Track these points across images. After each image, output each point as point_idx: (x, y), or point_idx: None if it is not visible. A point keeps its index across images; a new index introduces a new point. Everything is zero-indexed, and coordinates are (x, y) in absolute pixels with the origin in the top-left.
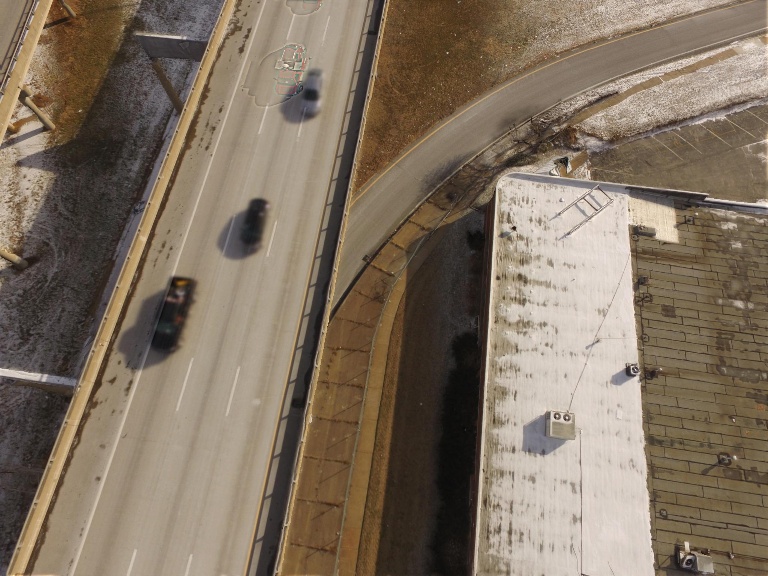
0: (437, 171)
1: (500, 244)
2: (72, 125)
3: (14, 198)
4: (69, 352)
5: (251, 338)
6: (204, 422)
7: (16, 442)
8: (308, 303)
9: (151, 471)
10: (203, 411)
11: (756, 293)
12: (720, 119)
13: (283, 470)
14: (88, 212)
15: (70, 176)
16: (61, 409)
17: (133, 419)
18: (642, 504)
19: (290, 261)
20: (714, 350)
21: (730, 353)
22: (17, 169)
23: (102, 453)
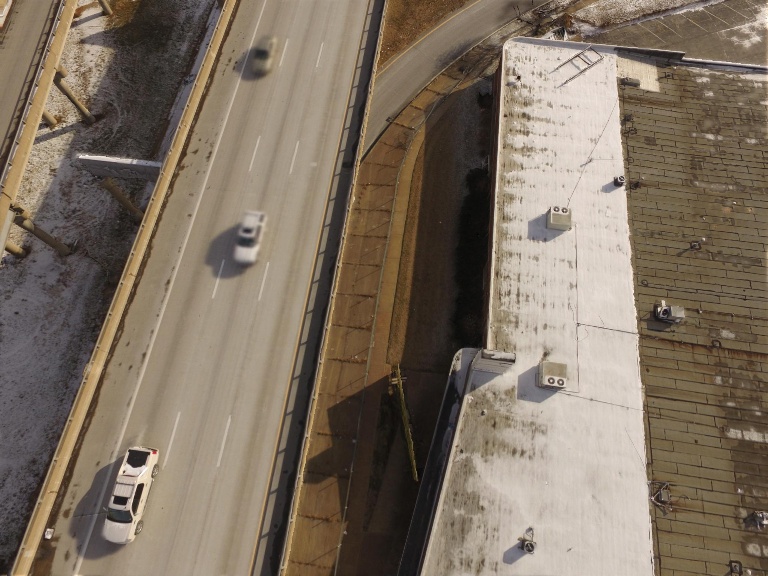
0: (450, 52)
1: (507, 91)
2: (127, 11)
3: (80, 69)
4: (135, 188)
5: (307, 122)
6: (272, 178)
7: (95, 254)
8: (352, 98)
9: (232, 210)
10: (271, 170)
11: (725, 128)
12: (698, 10)
13: (338, 207)
14: (145, 81)
15: (128, 52)
16: (131, 230)
17: (214, 176)
18: (627, 276)
19: (336, 70)
20: (688, 169)
21: (702, 171)
22: (81, 46)
23: (191, 199)
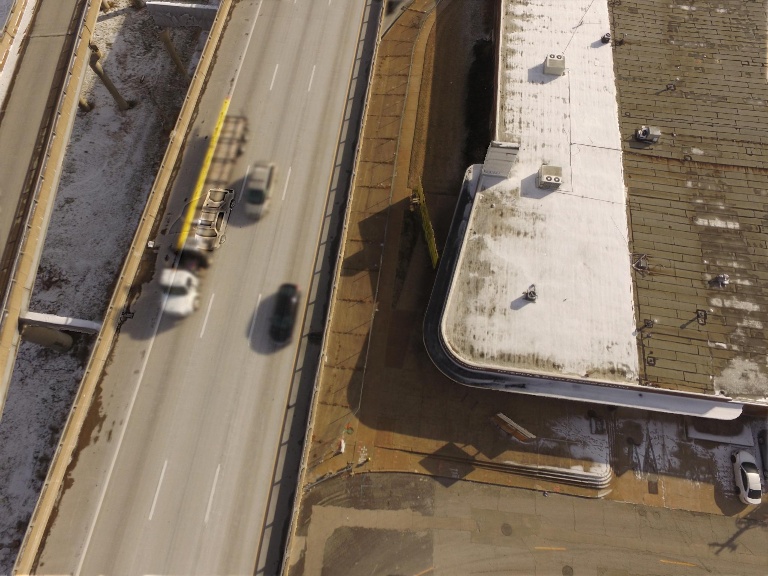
0: None
1: None
2: None
3: None
4: (182, 60)
5: None
6: (314, 7)
7: (150, 109)
8: None
9: (282, 30)
10: (313, 2)
11: (698, 1)
12: None
13: (371, 27)
14: None
15: None
16: (180, 92)
17: (266, 7)
18: (612, 109)
19: None
20: (666, 32)
21: (677, 33)
22: None
23: (247, 23)
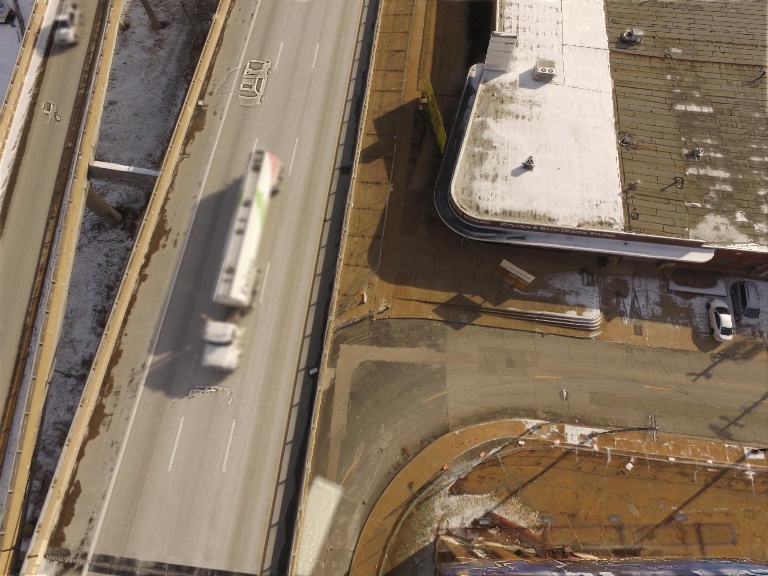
0: None
1: None
2: None
3: None
4: None
5: None
6: None
7: (180, 29)
8: None
9: None
10: None
11: None
12: None
13: None
14: None
15: None
16: (207, 15)
17: None
18: (600, 16)
19: None
20: None
21: None
22: None
23: None
